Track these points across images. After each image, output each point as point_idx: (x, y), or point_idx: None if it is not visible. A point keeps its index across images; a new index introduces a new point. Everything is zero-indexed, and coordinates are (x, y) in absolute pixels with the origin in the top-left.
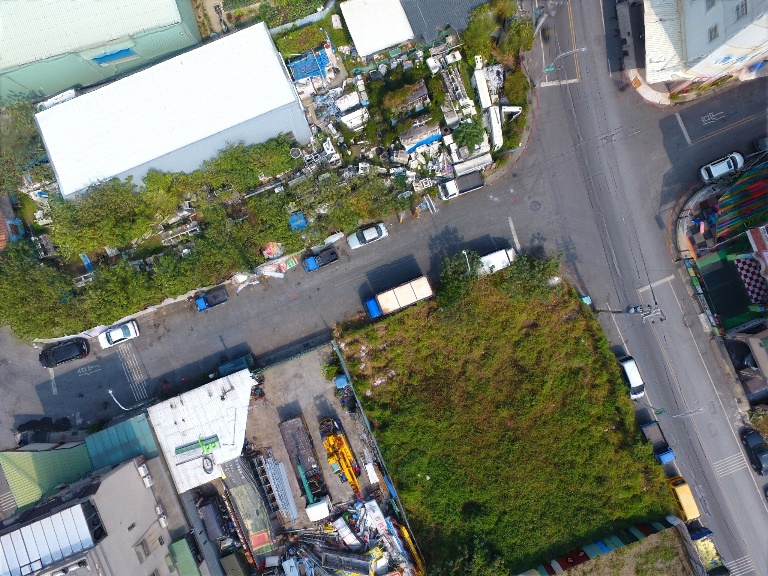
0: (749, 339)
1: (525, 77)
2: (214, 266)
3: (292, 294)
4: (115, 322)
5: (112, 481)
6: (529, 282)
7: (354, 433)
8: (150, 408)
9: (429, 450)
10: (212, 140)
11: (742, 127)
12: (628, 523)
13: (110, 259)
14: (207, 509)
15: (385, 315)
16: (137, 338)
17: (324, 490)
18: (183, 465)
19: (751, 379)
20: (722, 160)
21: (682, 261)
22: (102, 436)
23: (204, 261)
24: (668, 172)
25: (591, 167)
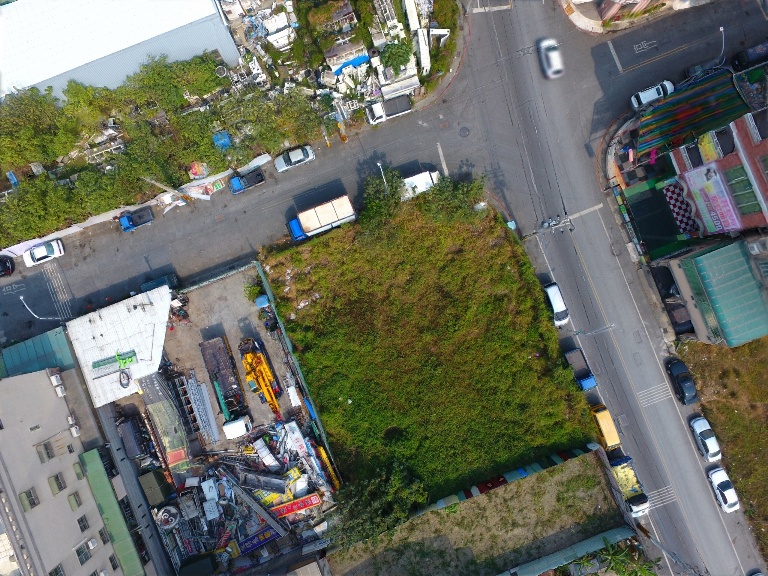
0: (670, 262)
1: (454, 0)
2: (136, 183)
3: (218, 216)
4: (39, 239)
5: (16, 382)
6: (451, 203)
7: (277, 356)
8: (69, 322)
9: (352, 374)
10: (132, 52)
11: (674, 56)
12: (550, 450)
13: (36, 178)
14: (125, 426)
15: (310, 237)
16: (62, 258)
17: (244, 410)
18: (100, 379)
19: (677, 309)
20: (652, 87)
21: (611, 189)
22: (19, 348)
23: (124, 175)
24: (599, 100)
25: (521, 94)
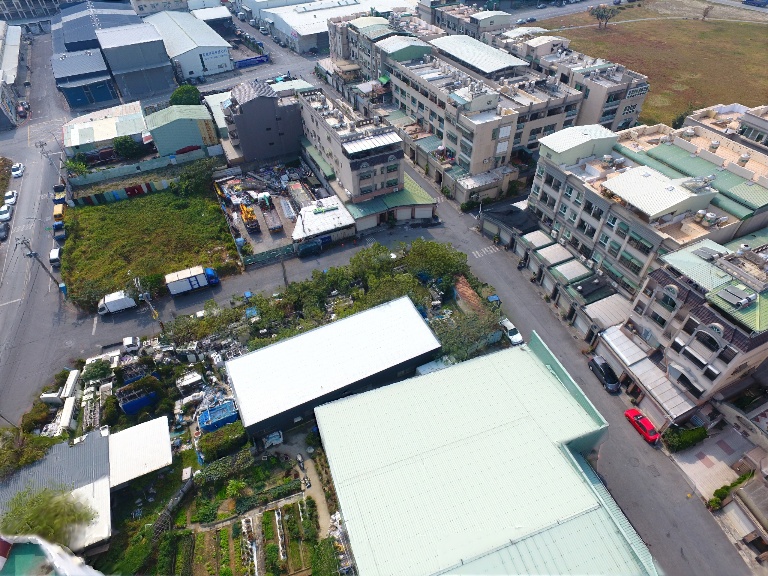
0: None
1: None
2: None
3: (269, 286)
4: None
5: None
6: None
7: (242, 230)
8: None
9: None
10: None
11: None
12: None
13: None
14: (325, 196)
15: None
16: None
17: None
18: None
19: None
20: None
21: None
22: (378, 210)
23: None
24: None
25: (7, 370)
